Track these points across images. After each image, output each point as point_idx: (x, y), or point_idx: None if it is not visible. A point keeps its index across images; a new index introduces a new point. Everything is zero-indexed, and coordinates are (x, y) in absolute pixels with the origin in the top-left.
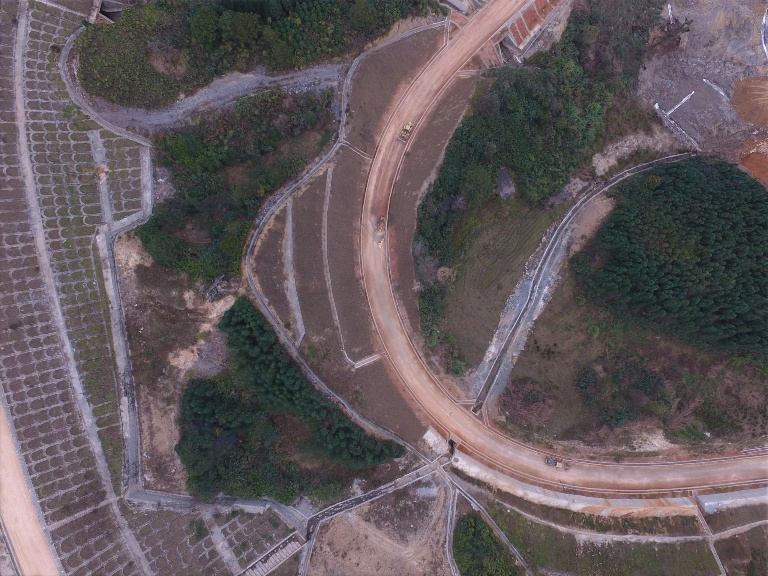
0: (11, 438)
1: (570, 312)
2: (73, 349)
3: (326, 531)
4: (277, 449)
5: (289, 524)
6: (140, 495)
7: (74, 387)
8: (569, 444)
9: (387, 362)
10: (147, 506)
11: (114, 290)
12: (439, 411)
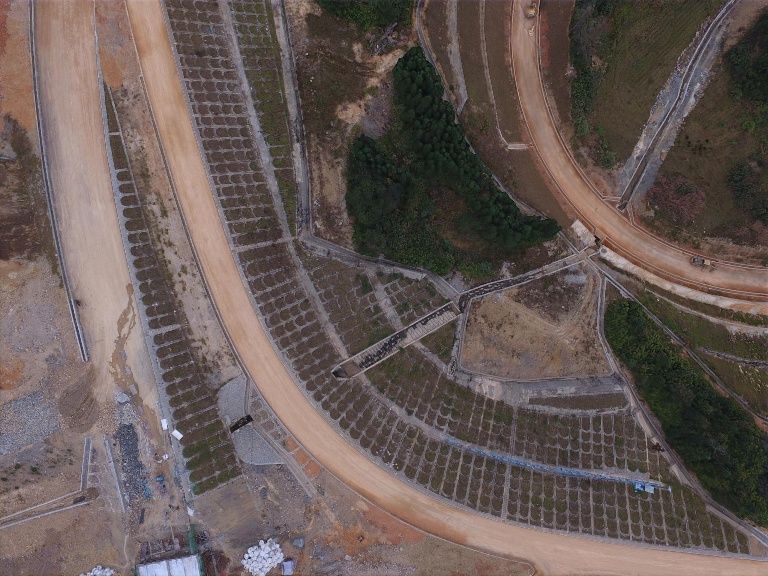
0: (200, 159)
1: (724, 108)
2: (250, 88)
3: (478, 306)
4: (433, 221)
5: (444, 295)
6: (311, 241)
7: (252, 125)
8: (717, 242)
9: (534, 153)
10: (319, 251)
11: (285, 38)
12: (584, 206)
